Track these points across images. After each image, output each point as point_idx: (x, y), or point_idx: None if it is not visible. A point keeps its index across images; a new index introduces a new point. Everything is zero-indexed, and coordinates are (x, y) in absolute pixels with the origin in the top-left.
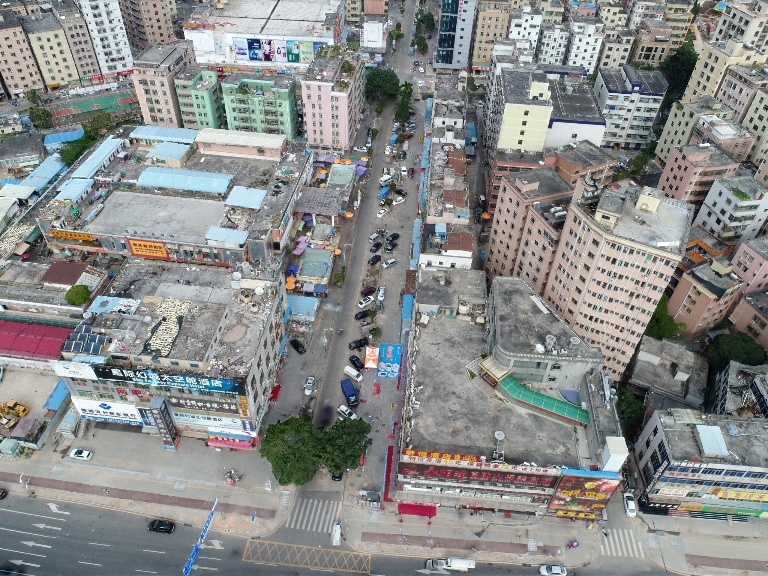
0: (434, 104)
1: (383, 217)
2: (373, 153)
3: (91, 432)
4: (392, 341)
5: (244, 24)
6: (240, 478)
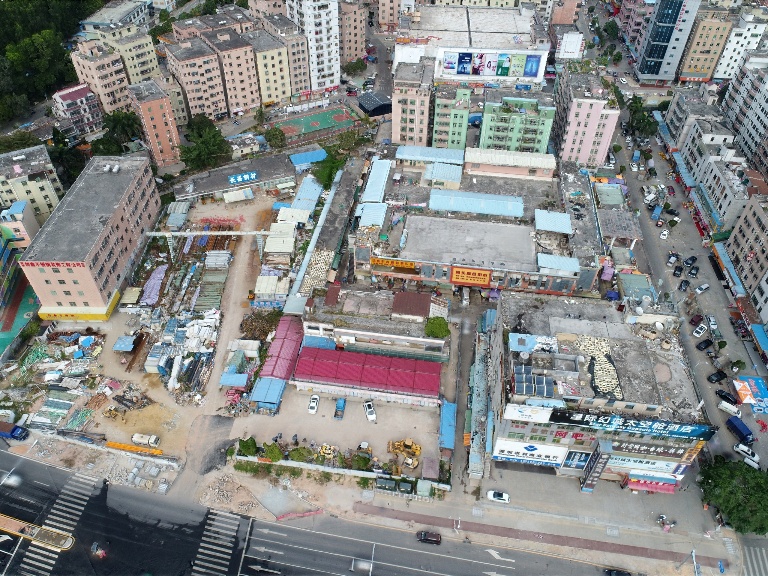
0: (689, 119)
1: (667, 239)
2: (619, 170)
3: (495, 472)
4: (749, 373)
5: (449, 37)
6: (674, 524)
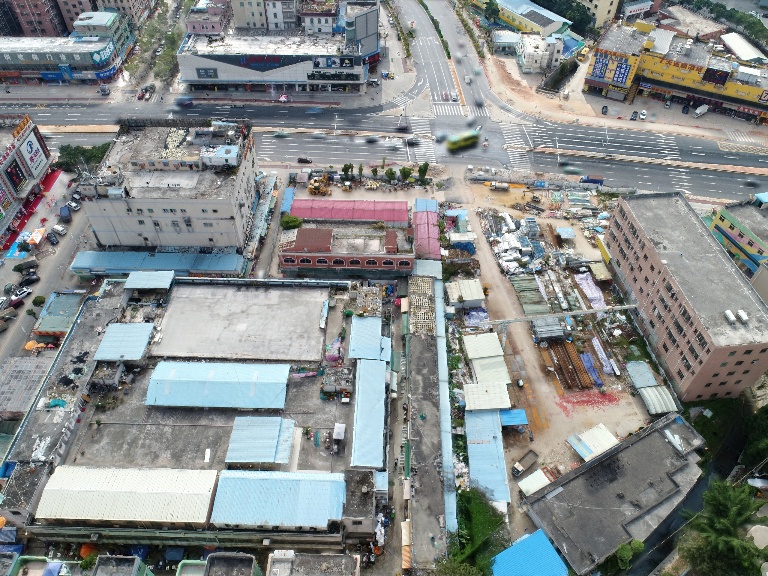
0: None
1: None
2: None
3: None
4: (12, 260)
5: None
6: None
